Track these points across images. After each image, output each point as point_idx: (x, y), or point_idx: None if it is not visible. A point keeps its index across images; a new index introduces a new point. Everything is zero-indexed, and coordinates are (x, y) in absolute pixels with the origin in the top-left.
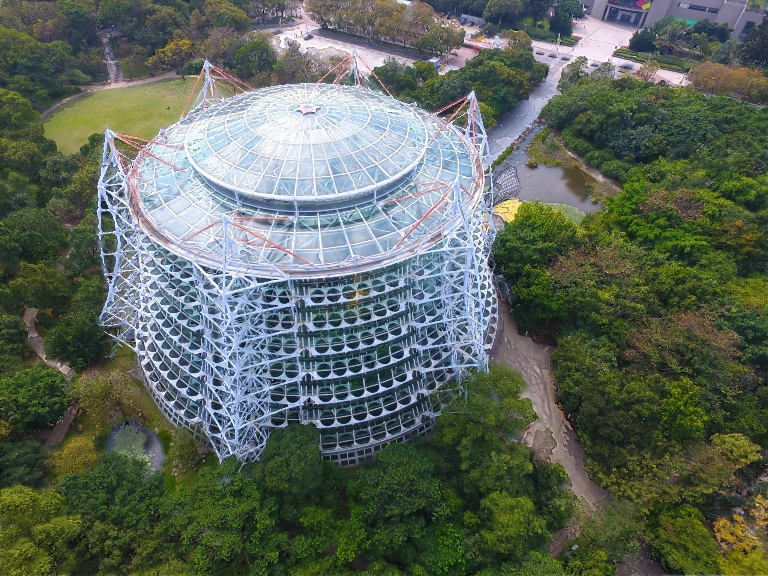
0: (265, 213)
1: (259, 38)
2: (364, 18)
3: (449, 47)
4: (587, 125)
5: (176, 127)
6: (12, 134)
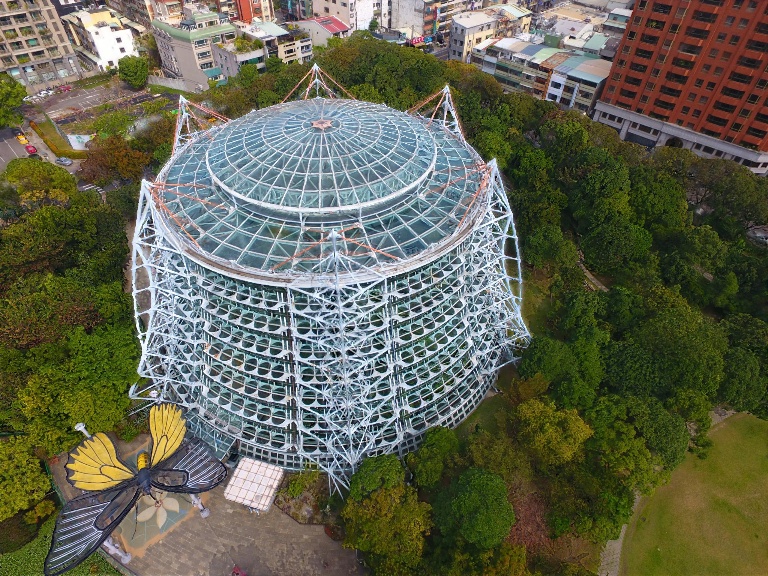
0: None
1: None
2: None
3: None
4: None
5: None
6: None
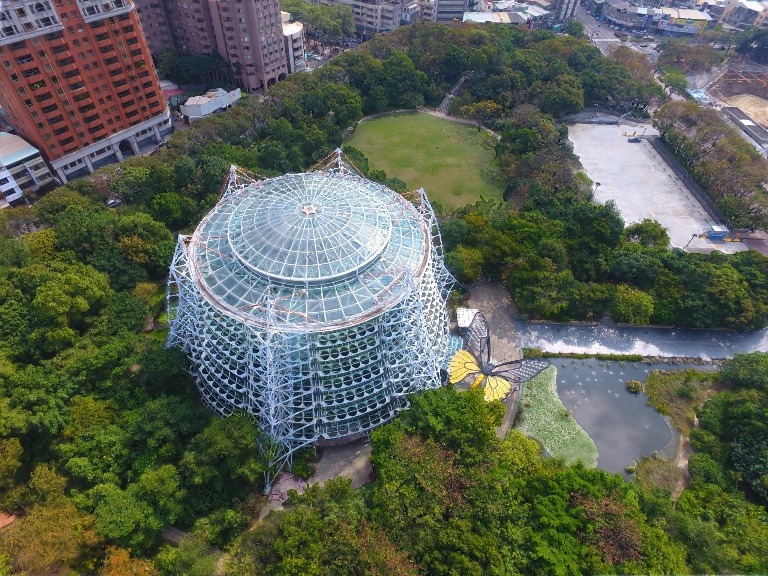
0: None
1: (539, 128)
2: (692, 149)
3: (755, 225)
4: (739, 405)
5: (300, 176)
6: (324, 124)
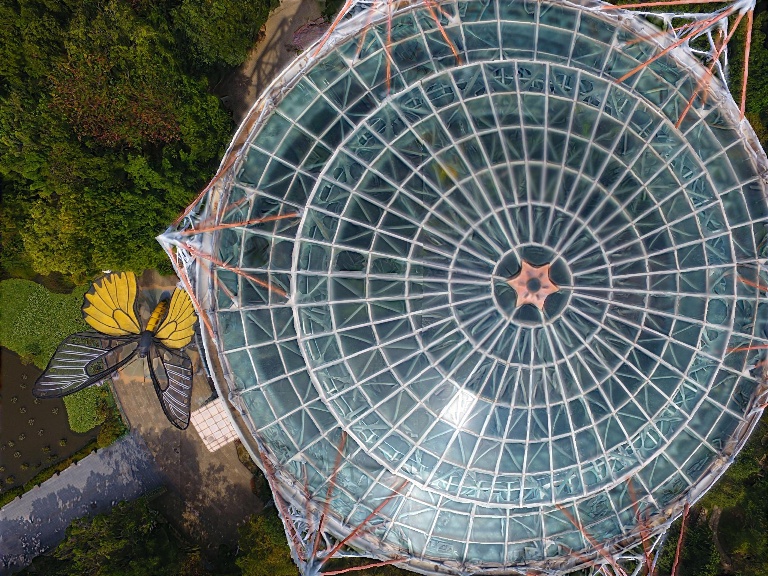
0: (633, 123)
1: None
2: None
3: None
4: None
5: (698, 479)
6: None
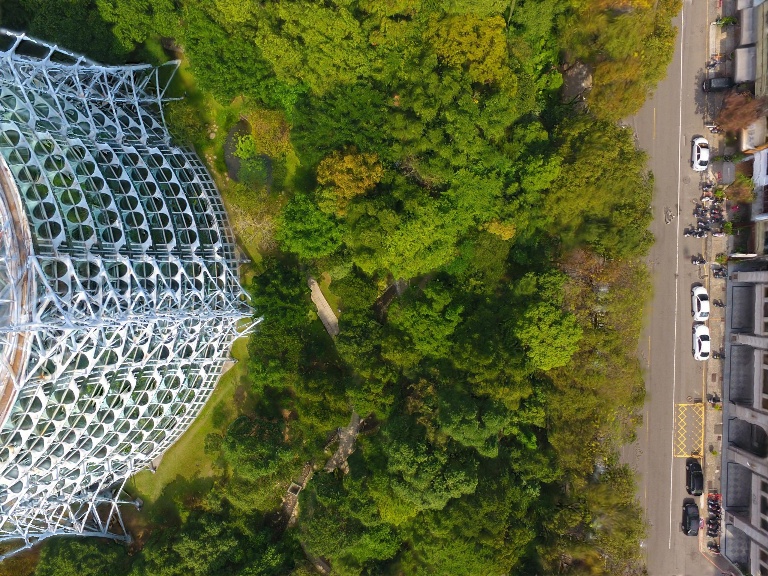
0: None
1: None
2: None
3: None
4: None
5: None
6: None
